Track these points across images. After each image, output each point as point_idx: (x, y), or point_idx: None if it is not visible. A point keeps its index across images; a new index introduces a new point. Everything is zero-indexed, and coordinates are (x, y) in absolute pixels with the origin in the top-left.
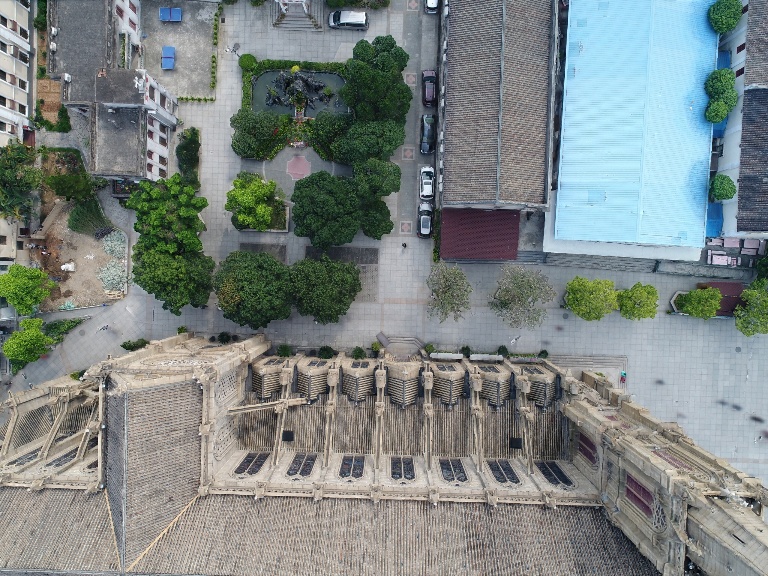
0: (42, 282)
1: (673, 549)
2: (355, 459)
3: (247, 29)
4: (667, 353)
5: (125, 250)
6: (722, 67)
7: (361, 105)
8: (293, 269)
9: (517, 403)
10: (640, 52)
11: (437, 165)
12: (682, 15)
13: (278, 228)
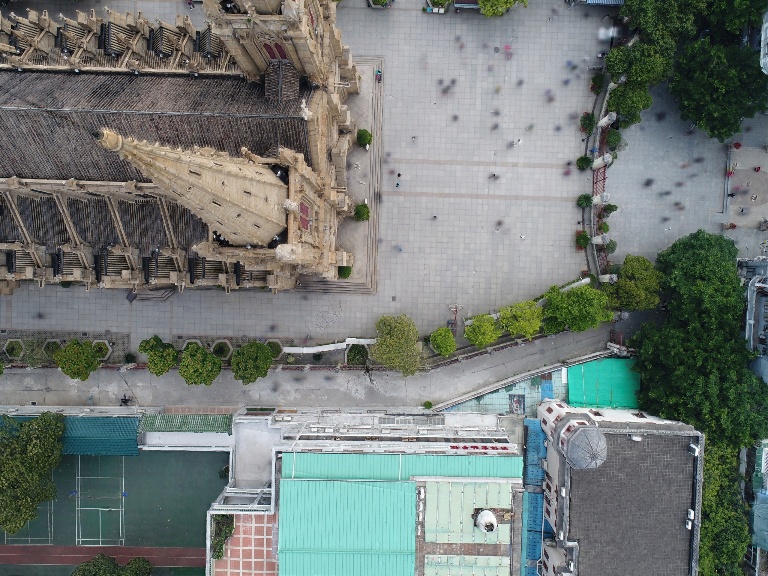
0: None
1: None
2: None
3: None
4: (424, 53)
5: None
6: None
7: None
8: None
9: None
10: None
11: None
12: None
13: None
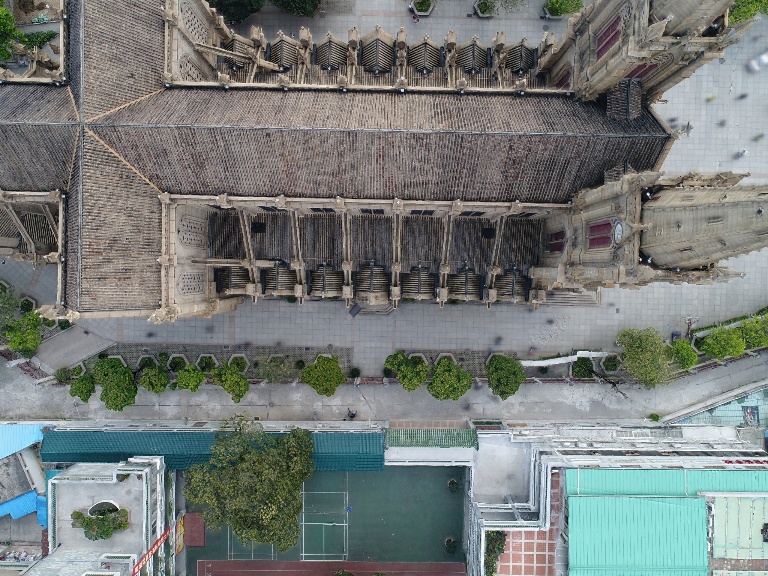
0: None
1: (638, 20)
2: None
3: None
4: None
5: None
6: None
7: None
8: None
9: (493, 70)
10: None
11: None
12: None
13: None
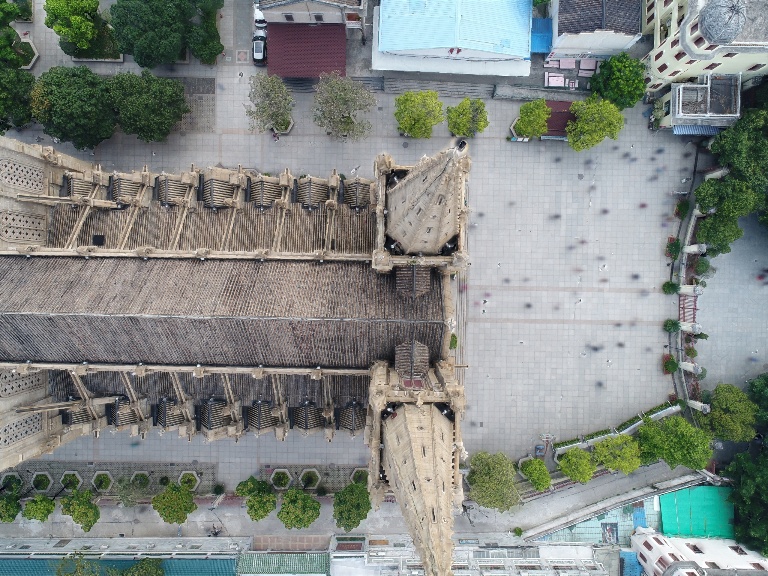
0: None
1: None
2: None
3: None
4: (509, 181)
5: None
6: None
7: None
8: (110, 80)
9: None
10: None
11: None
12: None
13: (112, 57)
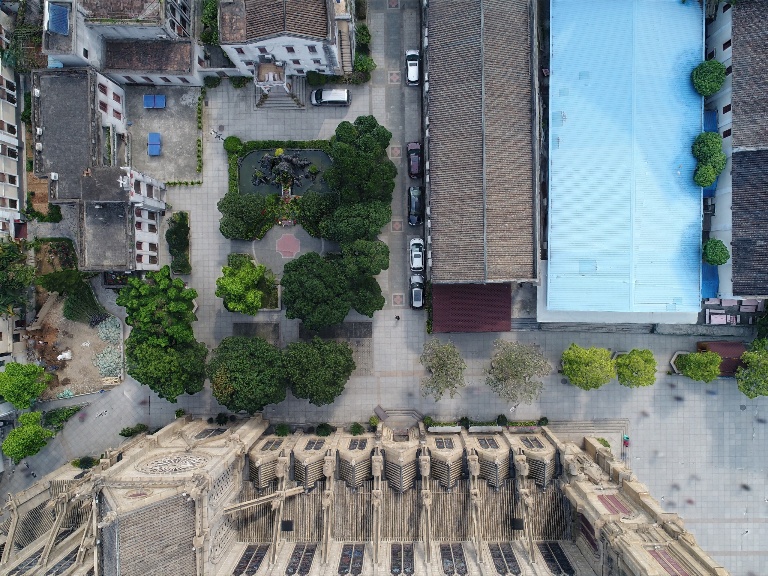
0: (39, 376)
1: None
2: (355, 548)
3: (231, 111)
4: (670, 414)
5: (120, 336)
6: (709, 127)
7: (345, 189)
8: (285, 354)
9: (517, 483)
10: (624, 120)
11: (426, 236)
12: (664, 80)
13: (270, 307)
